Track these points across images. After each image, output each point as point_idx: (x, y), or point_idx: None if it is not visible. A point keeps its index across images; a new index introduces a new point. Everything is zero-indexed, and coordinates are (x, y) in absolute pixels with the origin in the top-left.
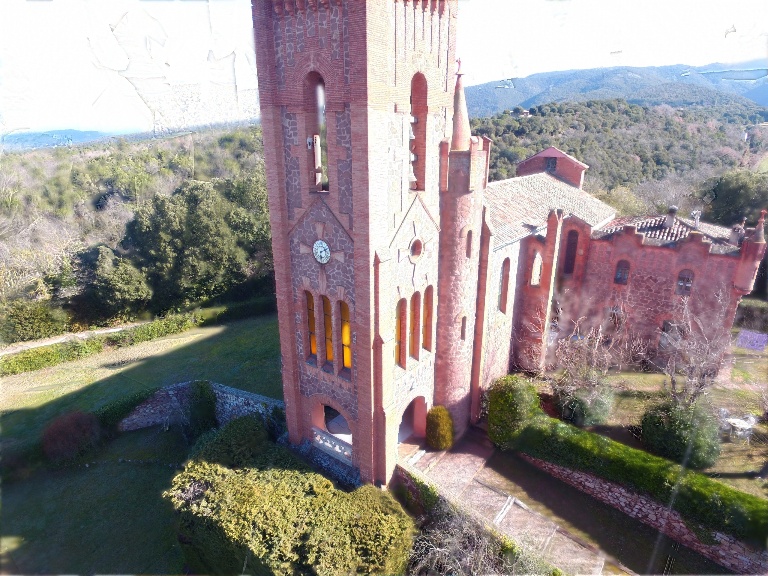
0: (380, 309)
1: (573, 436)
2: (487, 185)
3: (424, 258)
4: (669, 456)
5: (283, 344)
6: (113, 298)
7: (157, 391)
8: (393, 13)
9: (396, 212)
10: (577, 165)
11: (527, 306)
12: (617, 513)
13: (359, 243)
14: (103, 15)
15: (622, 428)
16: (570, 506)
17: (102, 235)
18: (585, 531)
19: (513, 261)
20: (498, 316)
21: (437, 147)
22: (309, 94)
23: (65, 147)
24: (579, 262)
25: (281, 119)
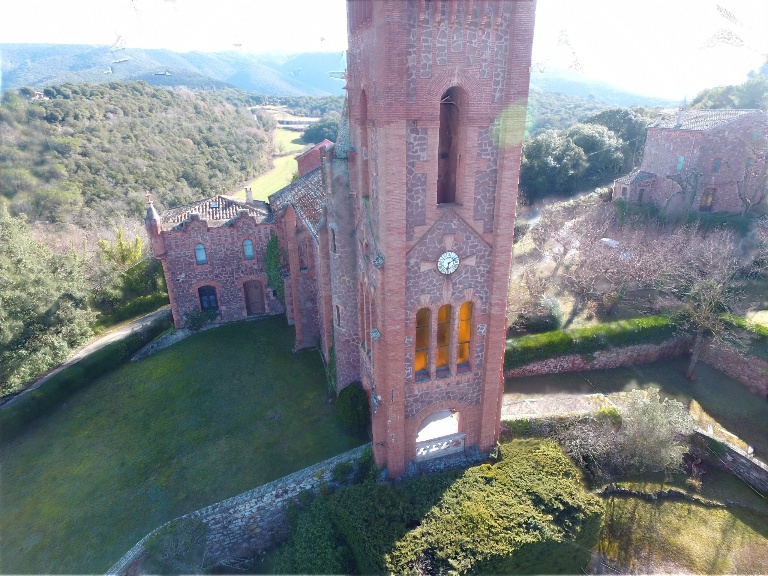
0: None
1: (521, 343)
2: None
3: None
4: (549, 330)
5: (393, 377)
6: None
7: None
8: None
9: None
10: None
11: None
12: (552, 375)
13: (503, 242)
14: None
15: (509, 331)
16: (540, 386)
17: None
18: (560, 392)
19: None
20: None
21: None
22: None
23: None
24: None
25: None
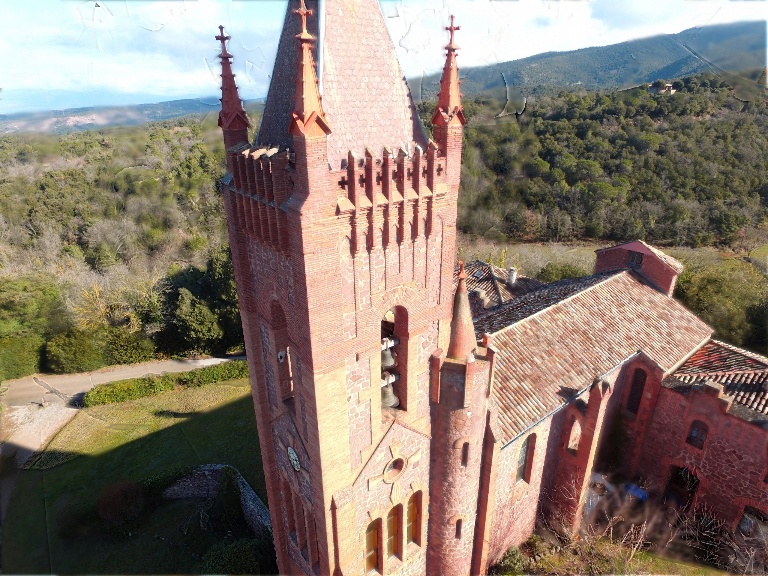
0: (340, 546)
1: None
2: (532, 317)
3: (408, 470)
4: None
5: (271, 510)
6: (189, 336)
7: (195, 469)
8: (351, 268)
9: (363, 448)
10: (668, 268)
11: (561, 469)
12: None
13: (316, 485)
14: (201, 54)
15: None
16: None
17: (202, 247)
18: None
19: (542, 431)
20: (518, 488)
21: (426, 362)
22: (280, 312)
23: (166, 179)
24: (645, 406)
25: (258, 322)
